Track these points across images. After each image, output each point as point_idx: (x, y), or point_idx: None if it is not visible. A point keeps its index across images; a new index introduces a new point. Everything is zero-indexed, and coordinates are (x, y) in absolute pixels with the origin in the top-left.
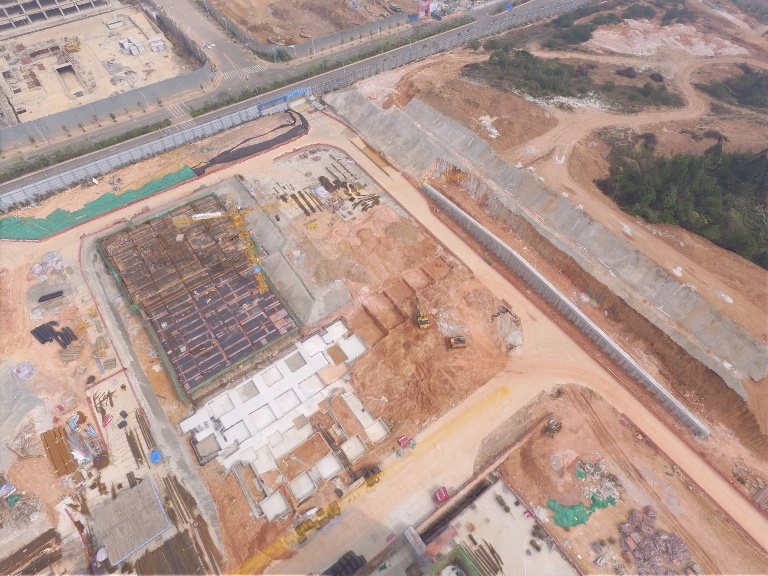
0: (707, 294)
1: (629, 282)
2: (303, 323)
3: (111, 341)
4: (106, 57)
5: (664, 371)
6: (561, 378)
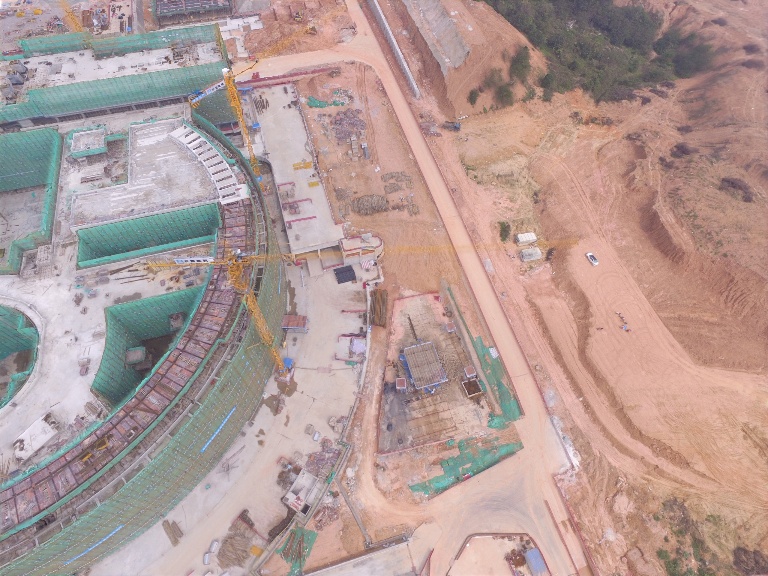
0: (460, 24)
1: (427, 20)
2: (236, 11)
3: None
4: None
5: (421, 69)
6: (359, 59)
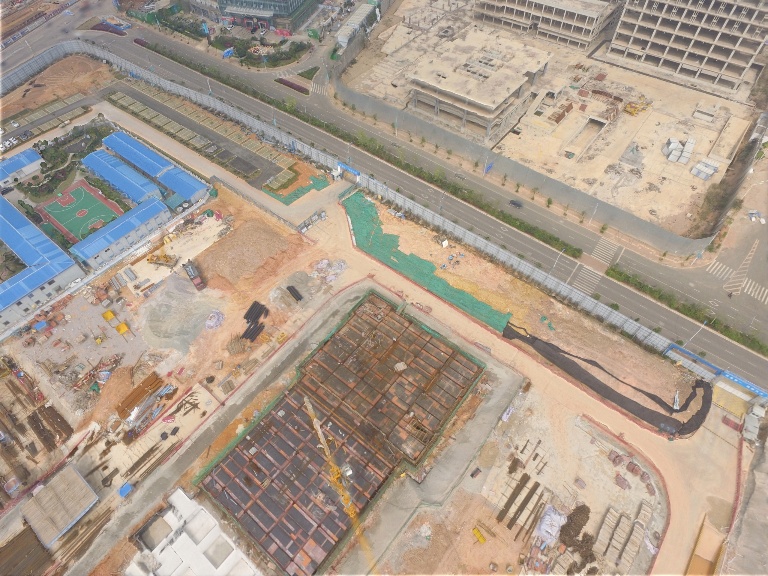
0: None
1: None
2: None
3: (253, 373)
4: (643, 140)
5: None
6: None
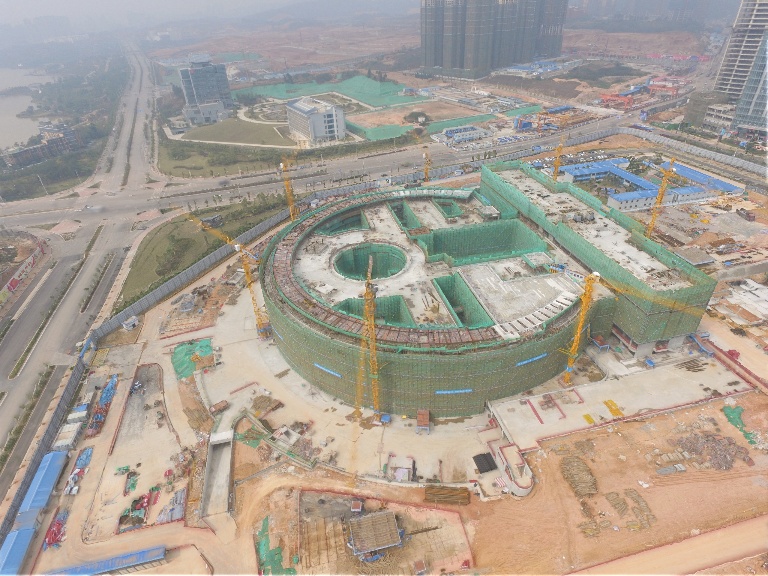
0: None
1: None
2: None
3: None
4: None
5: None
6: None
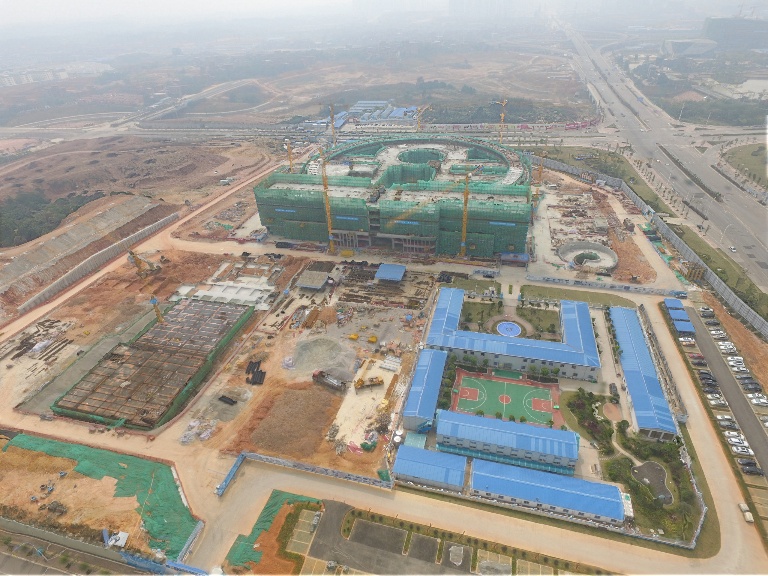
0: None
1: (106, 227)
2: None
3: (241, 347)
4: None
5: None
6: None
